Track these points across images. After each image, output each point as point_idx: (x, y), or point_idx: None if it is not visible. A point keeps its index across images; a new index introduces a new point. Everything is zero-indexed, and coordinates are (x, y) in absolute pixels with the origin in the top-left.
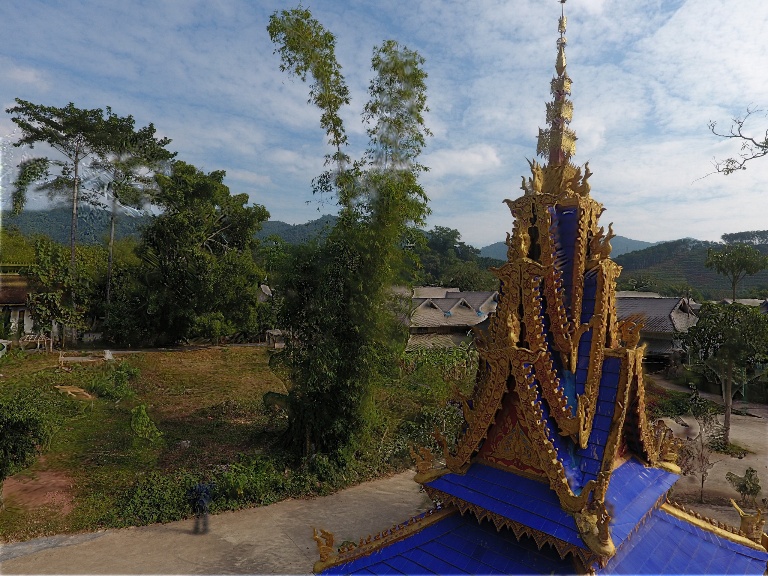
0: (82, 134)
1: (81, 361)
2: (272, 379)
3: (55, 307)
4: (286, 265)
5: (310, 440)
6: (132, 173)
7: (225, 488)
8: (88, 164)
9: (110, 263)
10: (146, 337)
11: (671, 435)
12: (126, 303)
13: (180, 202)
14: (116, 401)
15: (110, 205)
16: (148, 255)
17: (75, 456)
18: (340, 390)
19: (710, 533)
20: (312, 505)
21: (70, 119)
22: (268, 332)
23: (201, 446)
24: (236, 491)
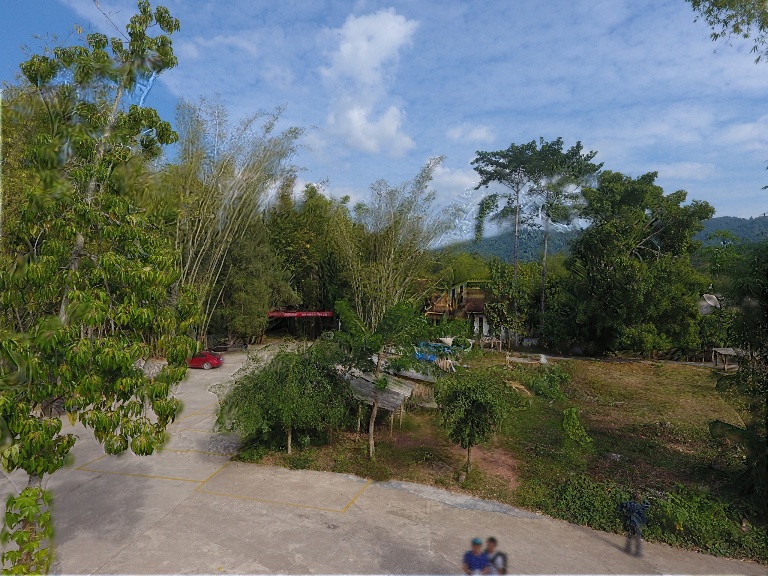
0: (522, 167)
1: (522, 362)
2: (721, 407)
3: (503, 315)
4: (740, 268)
5: None
6: (562, 192)
7: (660, 517)
8: (526, 192)
9: (544, 276)
10: (575, 345)
11: None
12: (557, 313)
13: (607, 212)
14: (550, 401)
15: (544, 224)
16: (577, 267)
17: (518, 442)
18: None
19: None
20: None
21: (513, 157)
22: (715, 350)
23: (632, 464)
24: (674, 525)
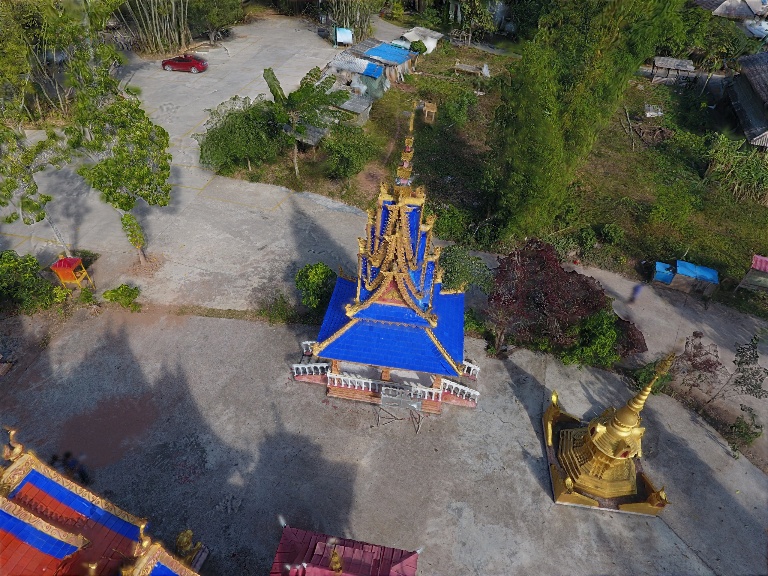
0: None
1: (467, 70)
2: None
3: (475, 6)
4: None
5: (490, 214)
6: None
7: None
8: None
9: None
10: None
11: (712, 359)
12: (531, 5)
13: None
14: (450, 125)
15: None
16: None
17: None
18: (501, 194)
19: (440, 353)
20: None
21: None
22: (654, 60)
23: (453, 185)
24: None
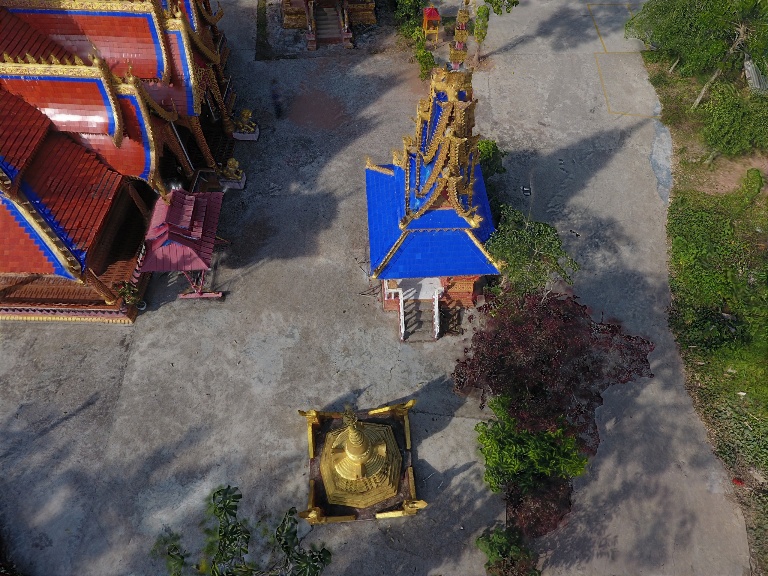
0: None
1: None
2: None
3: None
4: None
5: None
6: None
7: None
8: None
9: None
10: None
11: None
12: None
13: None
14: None
15: None
16: None
17: None
18: None
19: None
20: (656, 306)
21: None
22: None
23: None
24: None
